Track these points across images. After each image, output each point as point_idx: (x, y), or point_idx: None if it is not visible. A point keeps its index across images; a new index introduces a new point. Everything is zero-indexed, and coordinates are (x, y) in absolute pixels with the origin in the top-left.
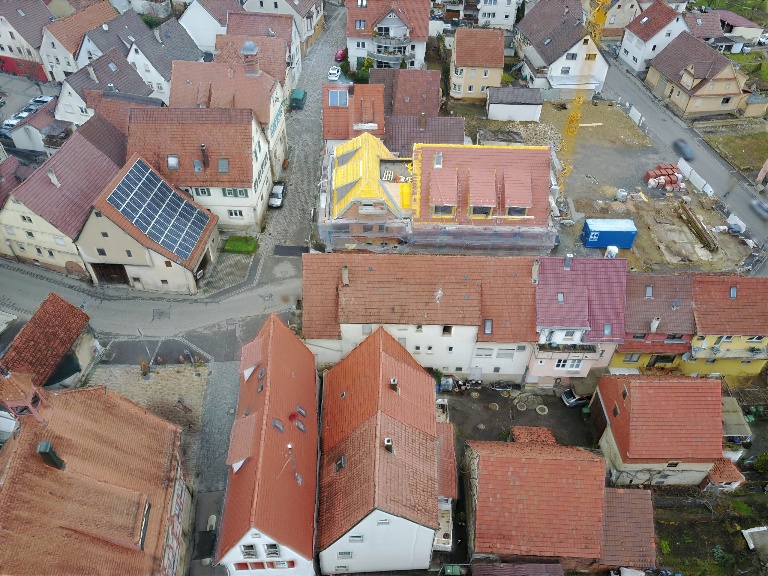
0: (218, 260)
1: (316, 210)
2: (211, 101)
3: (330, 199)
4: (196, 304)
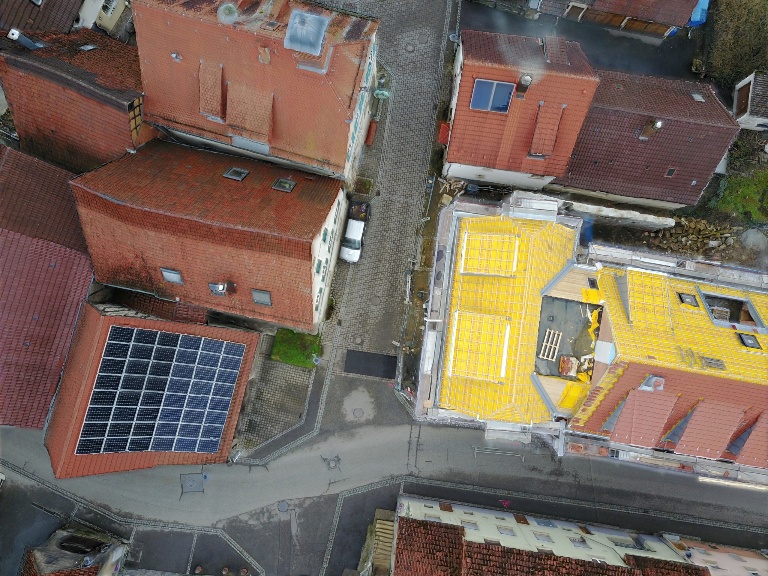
0: (262, 375)
1: (415, 266)
2: (227, 108)
3: (441, 342)
4: (236, 468)
